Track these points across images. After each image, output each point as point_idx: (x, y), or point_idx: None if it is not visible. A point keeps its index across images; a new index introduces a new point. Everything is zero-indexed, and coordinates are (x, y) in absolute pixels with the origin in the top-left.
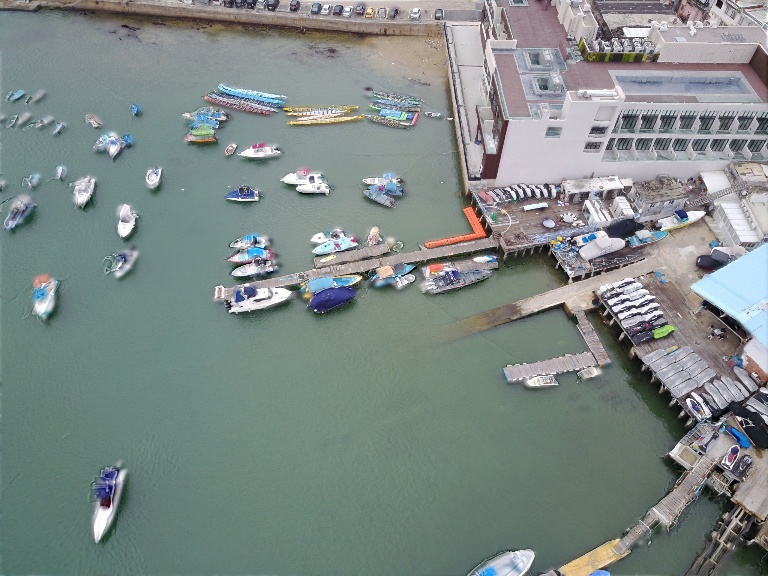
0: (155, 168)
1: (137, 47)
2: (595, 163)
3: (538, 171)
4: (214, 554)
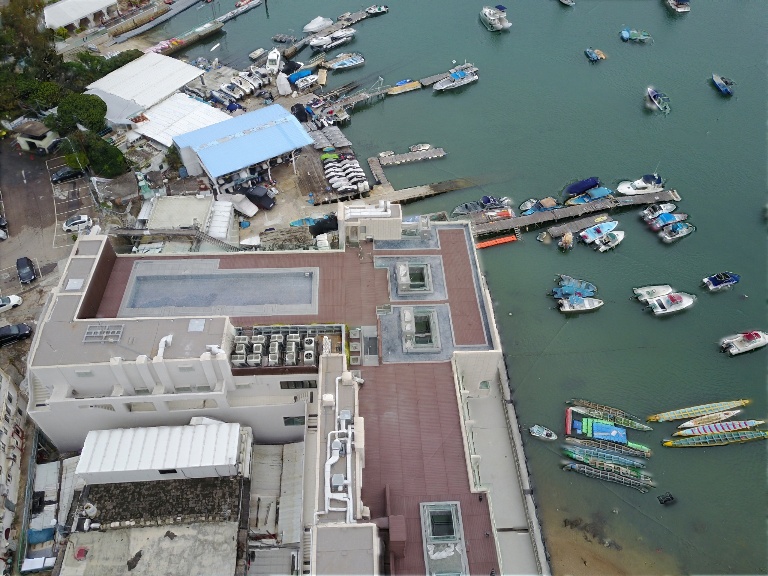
0: None
1: None
2: None
3: None
4: (590, 96)
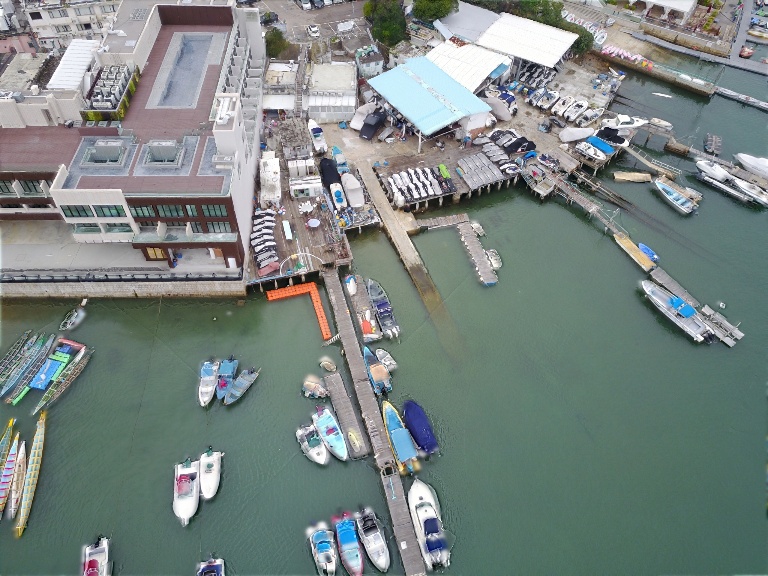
0: None
1: None
2: (250, 166)
3: (247, 213)
4: (731, 531)
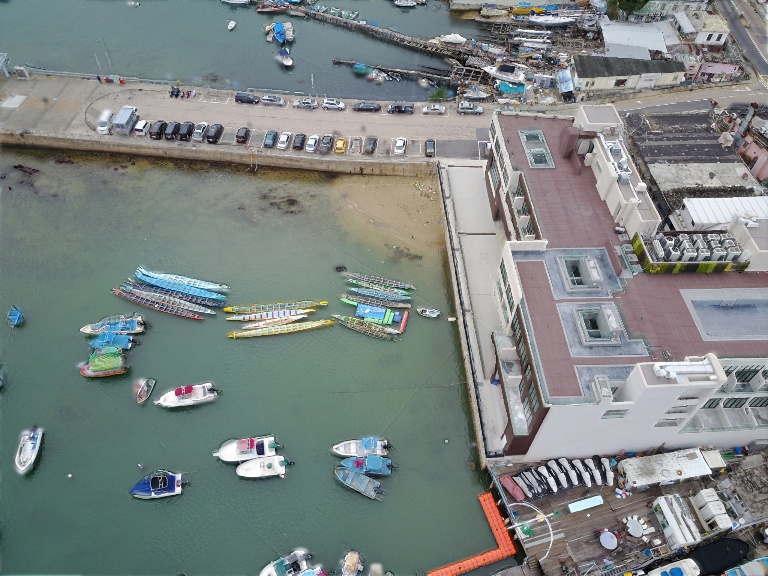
0: (33, 432)
1: (31, 202)
2: (668, 435)
3: (586, 445)
4: None
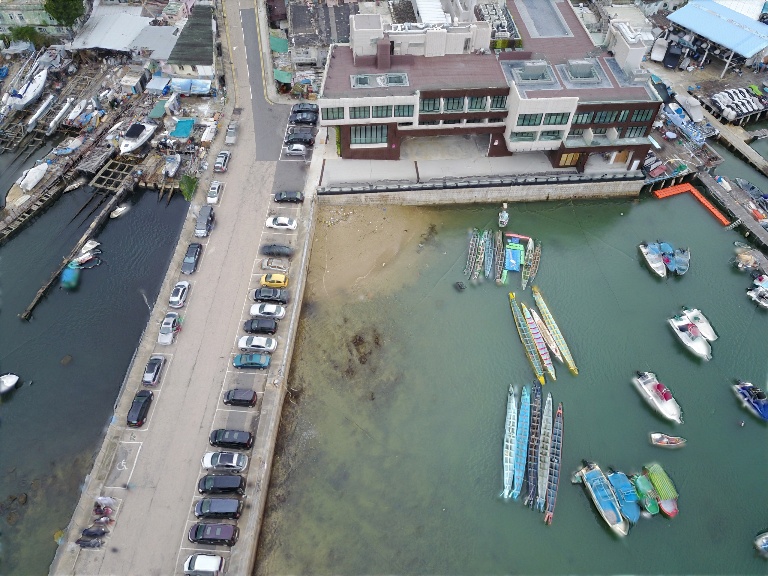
0: (761, 548)
1: None
2: None
3: None
4: None
